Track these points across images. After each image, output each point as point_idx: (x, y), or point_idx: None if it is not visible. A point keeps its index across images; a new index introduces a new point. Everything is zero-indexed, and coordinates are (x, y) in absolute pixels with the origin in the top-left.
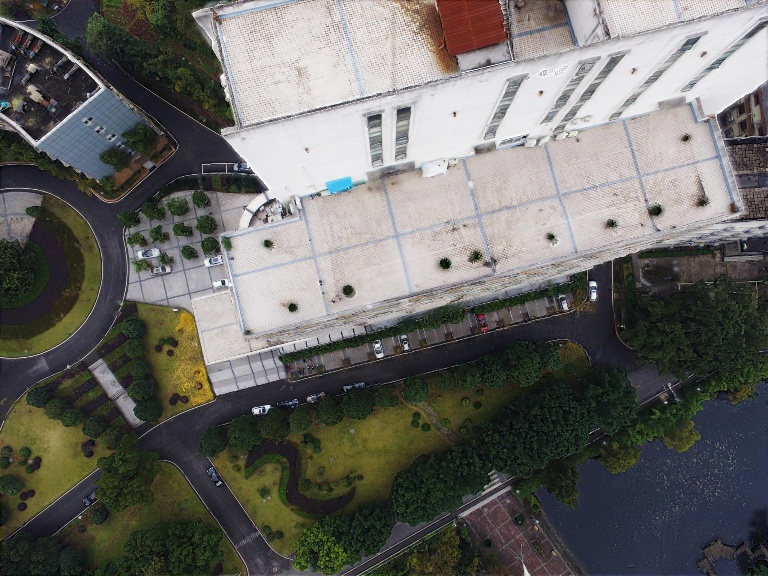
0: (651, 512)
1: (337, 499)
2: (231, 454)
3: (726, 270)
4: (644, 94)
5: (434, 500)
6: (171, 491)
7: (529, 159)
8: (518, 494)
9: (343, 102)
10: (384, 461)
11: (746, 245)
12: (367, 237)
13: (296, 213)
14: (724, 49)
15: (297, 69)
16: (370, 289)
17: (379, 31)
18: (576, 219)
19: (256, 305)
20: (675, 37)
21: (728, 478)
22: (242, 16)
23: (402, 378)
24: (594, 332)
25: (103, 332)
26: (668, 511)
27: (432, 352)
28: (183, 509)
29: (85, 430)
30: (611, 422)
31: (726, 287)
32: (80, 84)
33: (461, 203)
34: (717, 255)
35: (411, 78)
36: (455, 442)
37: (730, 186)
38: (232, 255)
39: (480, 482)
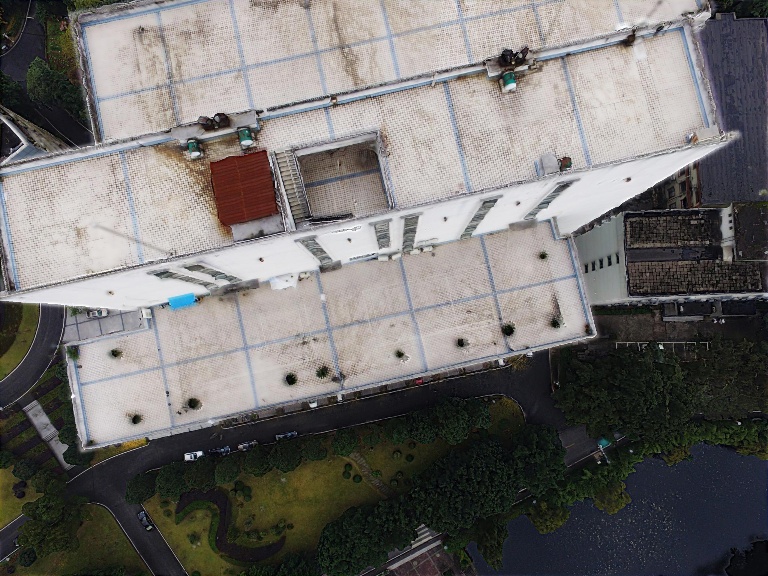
0: (583, 571)
1: (266, 547)
2: (162, 499)
3: (665, 330)
4: (483, 224)
5: (359, 555)
6: (102, 534)
7: (383, 273)
8: (446, 550)
9: (113, 270)
10: (315, 511)
11: (683, 308)
12: (216, 348)
13: (142, 324)
14: (541, 198)
15: (77, 229)
16: (217, 401)
17: (162, 192)
18: (428, 336)
19: (101, 415)
20: (468, 201)
21: (662, 539)
22: (25, 173)
23: (335, 428)
24: (530, 388)
25: (39, 374)
26: (600, 571)
27: (366, 403)
28: (113, 552)
29: (15, 473)
30: (537, 484)
31: (653, 356)
32: (4, 139)
33: (312, 316)
34: (656, 314)
35: (191, 241)
36: (386, 494)
37: (585, 307)
38: (80, 363)
39: (406, 539)
